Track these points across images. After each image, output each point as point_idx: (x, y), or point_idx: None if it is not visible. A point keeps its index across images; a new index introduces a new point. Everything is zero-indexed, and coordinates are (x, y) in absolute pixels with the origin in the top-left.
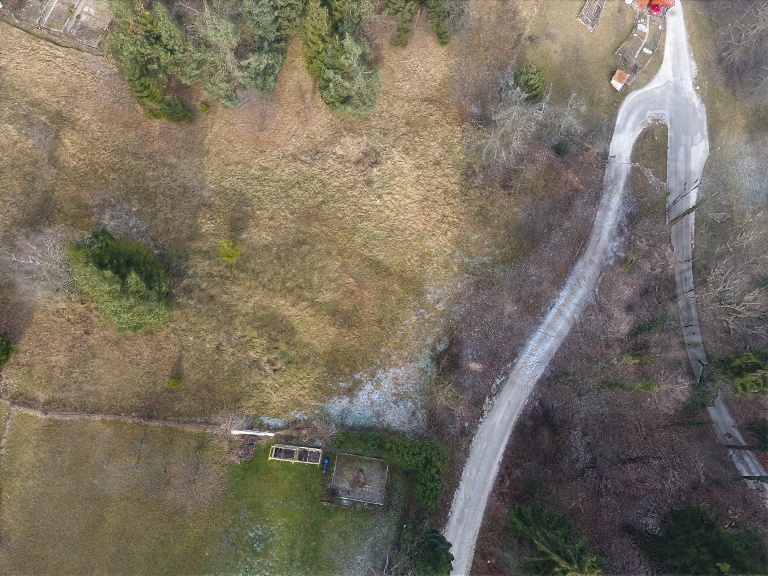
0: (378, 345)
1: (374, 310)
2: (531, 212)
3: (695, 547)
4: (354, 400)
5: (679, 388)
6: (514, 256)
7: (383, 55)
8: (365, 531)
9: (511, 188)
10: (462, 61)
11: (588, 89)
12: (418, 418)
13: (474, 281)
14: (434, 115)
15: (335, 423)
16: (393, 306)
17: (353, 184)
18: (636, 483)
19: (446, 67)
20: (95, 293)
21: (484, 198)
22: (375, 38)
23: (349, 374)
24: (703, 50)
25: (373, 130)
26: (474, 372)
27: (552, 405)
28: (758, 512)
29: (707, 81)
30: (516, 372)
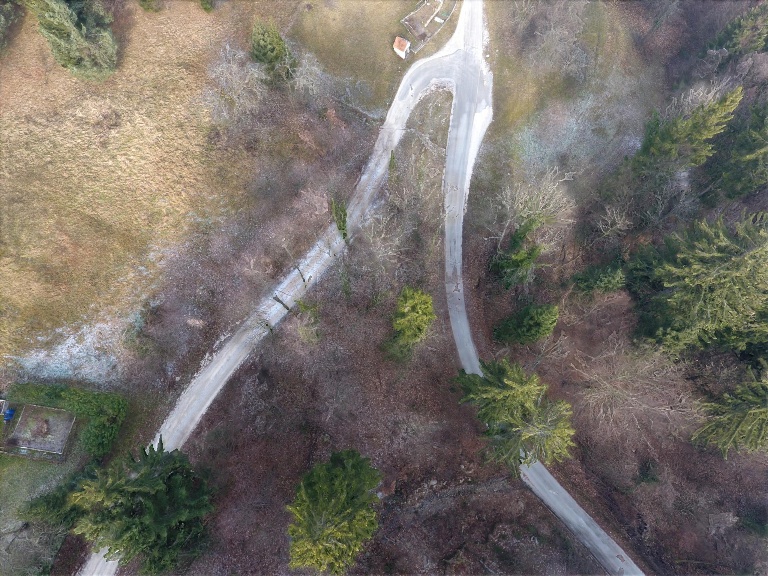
0: (87, 301)
1: (87, 267)
2: (276, 174)
3: (307, 483)
4: (52, 353)
5: (310, 330)
6: (253, 216)
7: (136, 20)
8: (38, 479)
9: (256, 150)
10: (231, 28)
11: (369, 56)
12: (118, 371)
13: (204, 240)
14: (185, 79)
15: (28, 376)
16: (110, 263)
17: (87, 145)
18: (363, 438)
19: (212, 33)
20: None
21: (225, 159)
22: (121, 2)
23: (50, 328)
24: (498, 19)
25: (118, 93)
26: (192, 328)
27: (276, 361)
28: (502, 469)
29: (498, 49)
30: (243, 329)
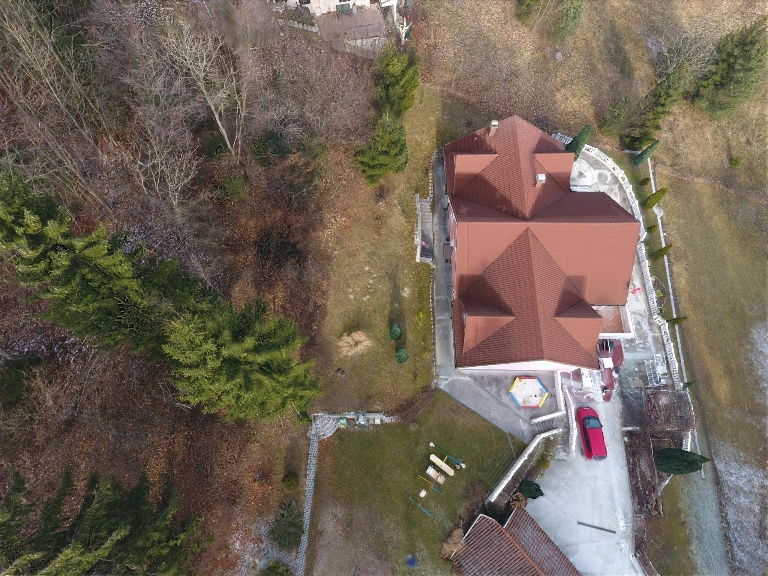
0: None
1: None
2: None
3: None
4: None
5: None
6: None
7: None
8: None
9: None
10: None
11: None
12: None
13: None
14: None
15: None
16: None
17: None
18: None
19: None
20: (767, 54)
21: None
22: None
23: None
24: None
25: None
26: None
27: None
28: None
29: None
30: None
